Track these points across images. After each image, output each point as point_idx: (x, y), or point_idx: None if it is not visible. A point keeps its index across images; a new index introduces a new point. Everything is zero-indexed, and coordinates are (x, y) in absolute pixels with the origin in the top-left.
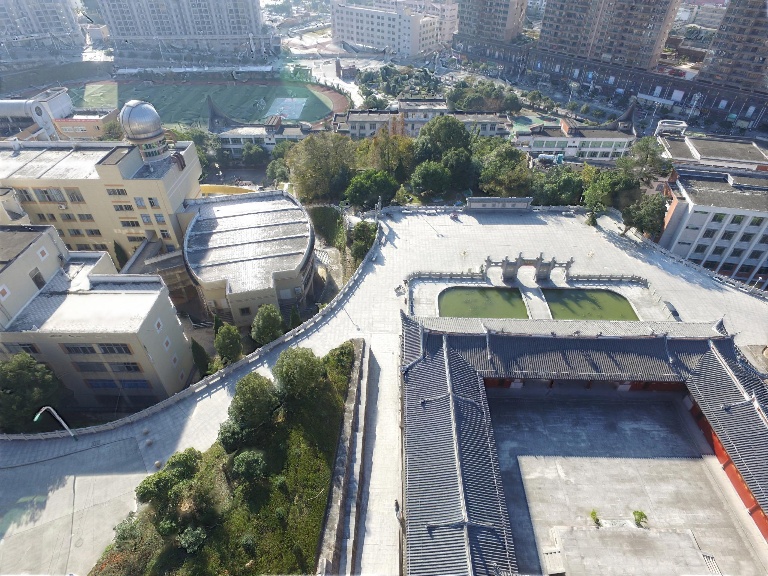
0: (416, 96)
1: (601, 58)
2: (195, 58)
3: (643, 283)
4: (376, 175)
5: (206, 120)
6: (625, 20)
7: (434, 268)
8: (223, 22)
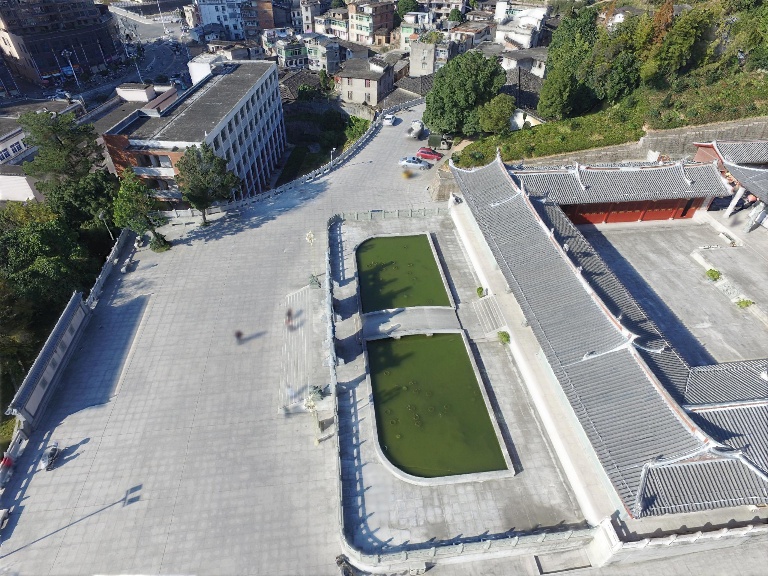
0: None
1: None
2: None
3: (335, 221)
4: None
5: None
6: None
7: (281, 504)
8: None
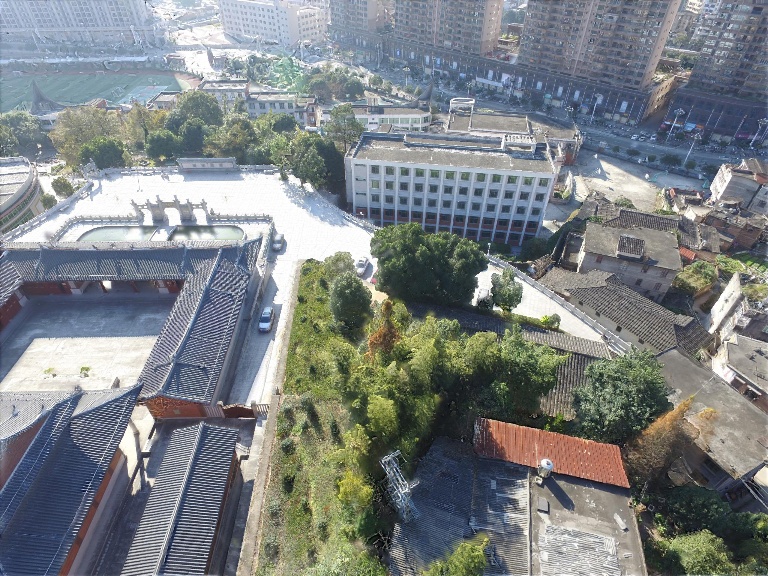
0: (220, 78)
1: (444, 45)
2: (70, 49)
3: None
4: (100, 141)
5: (29, 103)
6: (458, 9)
7: None
8: (104, 14)
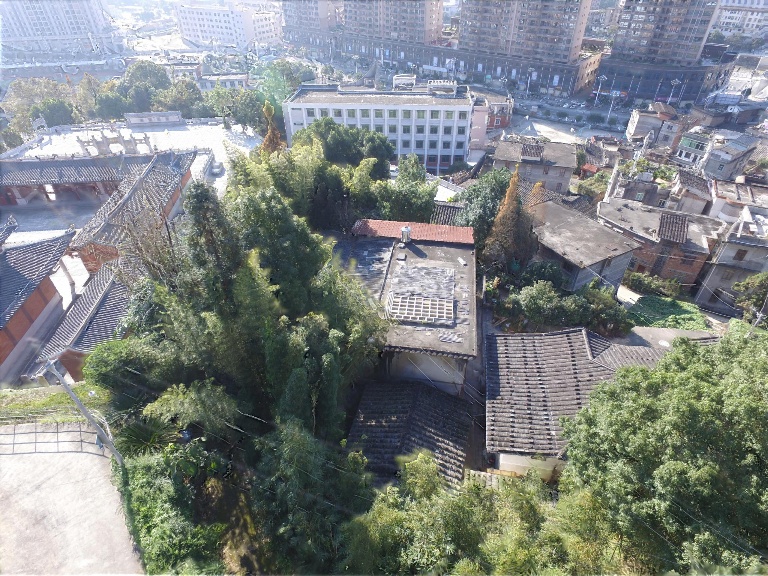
0: (172, 61)
1: (391, 36)
2: (28, 55)
3: None
4: (50, 101)
5: None
6: (401, 2)
7: None
8: (61, 23)
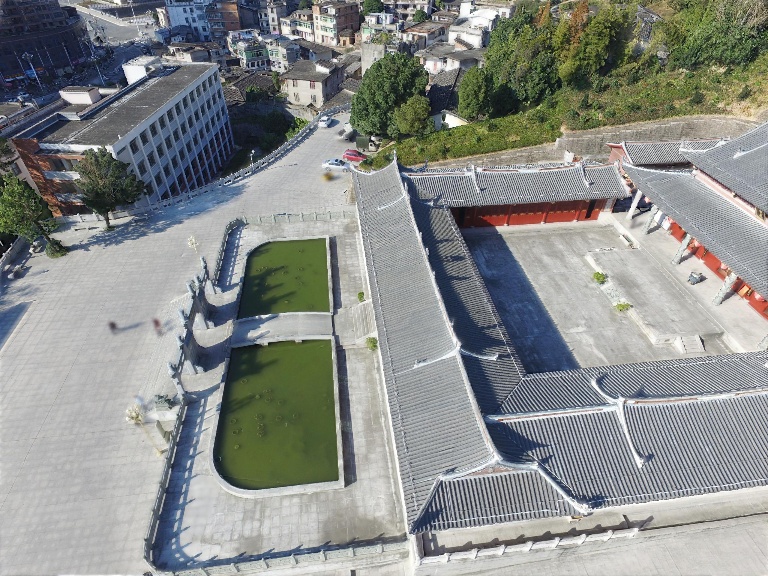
0: None
1: None
2: None
3: (237, 225)
4: None
5: None
6: None
7: (104, 518)
8: None
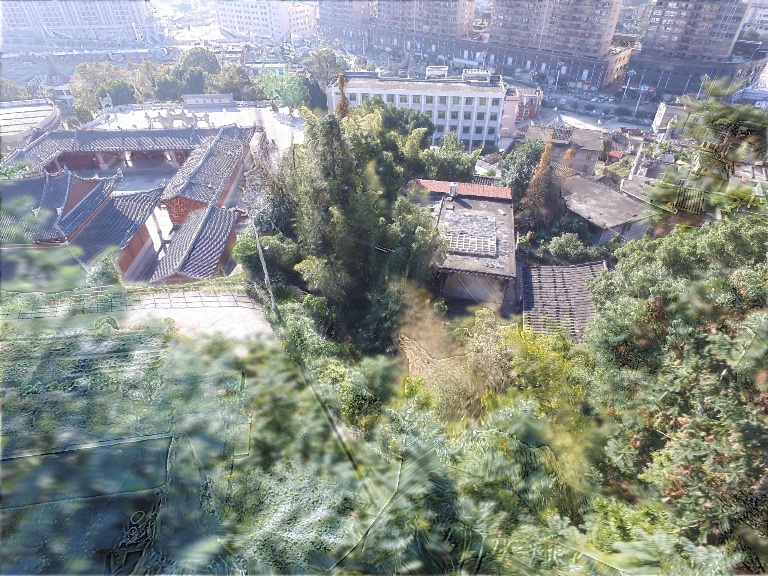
0: (218, 49)
1: (423, 30)
2: (77, 43)
3: None
4: (115, 82)
5: (44, 76)
6: None
7: None
8: (108, 13)
